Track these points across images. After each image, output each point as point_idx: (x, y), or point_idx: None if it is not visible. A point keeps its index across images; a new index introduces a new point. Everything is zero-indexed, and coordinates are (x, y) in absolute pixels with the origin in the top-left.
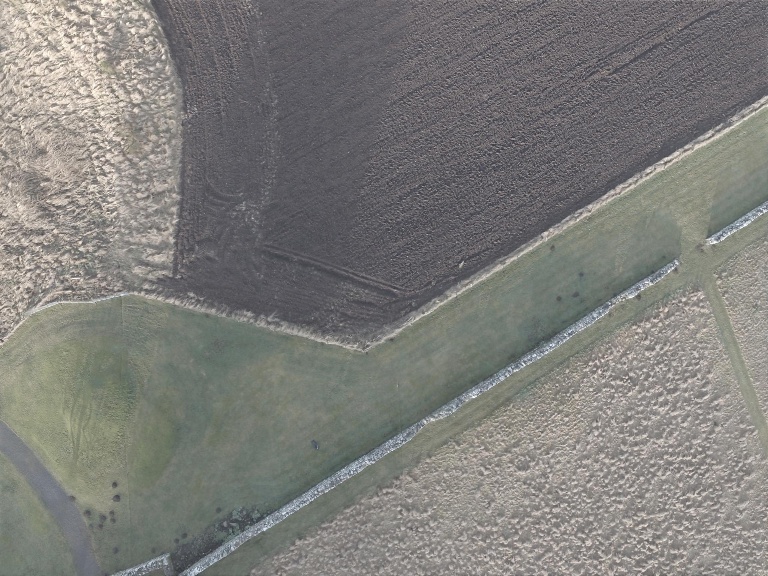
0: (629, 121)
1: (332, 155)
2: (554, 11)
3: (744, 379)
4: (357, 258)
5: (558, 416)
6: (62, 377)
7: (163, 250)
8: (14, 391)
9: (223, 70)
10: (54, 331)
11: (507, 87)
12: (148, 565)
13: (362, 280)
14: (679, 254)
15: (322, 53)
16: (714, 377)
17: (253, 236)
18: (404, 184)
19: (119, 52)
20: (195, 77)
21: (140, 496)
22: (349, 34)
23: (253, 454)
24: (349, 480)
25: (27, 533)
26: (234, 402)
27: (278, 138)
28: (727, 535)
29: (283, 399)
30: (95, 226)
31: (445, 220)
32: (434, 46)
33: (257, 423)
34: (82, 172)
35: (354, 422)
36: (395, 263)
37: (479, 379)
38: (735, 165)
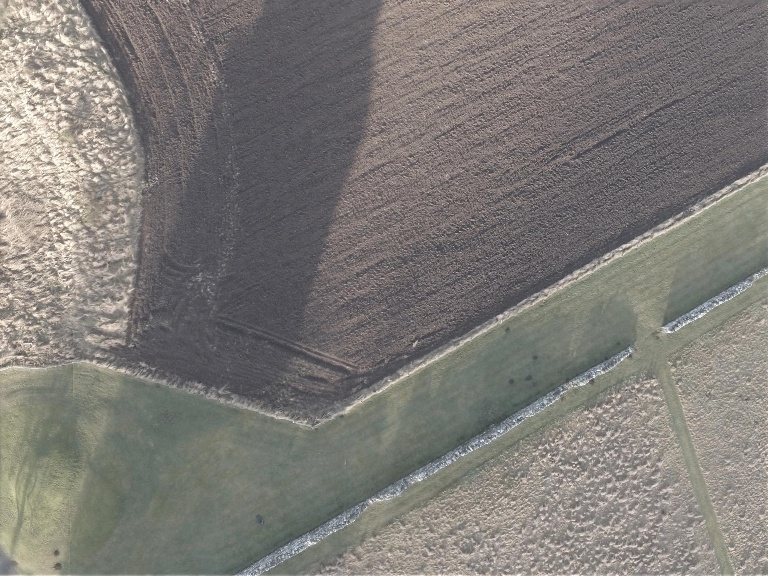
0: (589, 206)
1: (291, 229)
2: (519, 94)
3: (694, 468)
4: (311, 333)
5: (505, 499)
6: (10, 443)
7: (117, 319)
8: None
9: (186, 141)
10: (4, 395)
11: (469, 168)
12: None
13: (315, 355)
14: (634, 341)
15: (286, 127)
16: (664, 465)
17: (208, 308)
18: (361, 261)
19: (81, 121)
20: (157, 147)
21: (82, 565)
22: (313, 109)
23: (197, 526)
24: (293, 556)
25: None
26: (181, 474)
27: (238, 210)
28: None
29: (230, 472)
30: (50, 292)
31: (401, 299)
32: (398, 124)
33: (203, 495)
34: (40, 238)
35: (300, 498)
36: (349, 340)
37: (427, 460)
38: (694, 253)
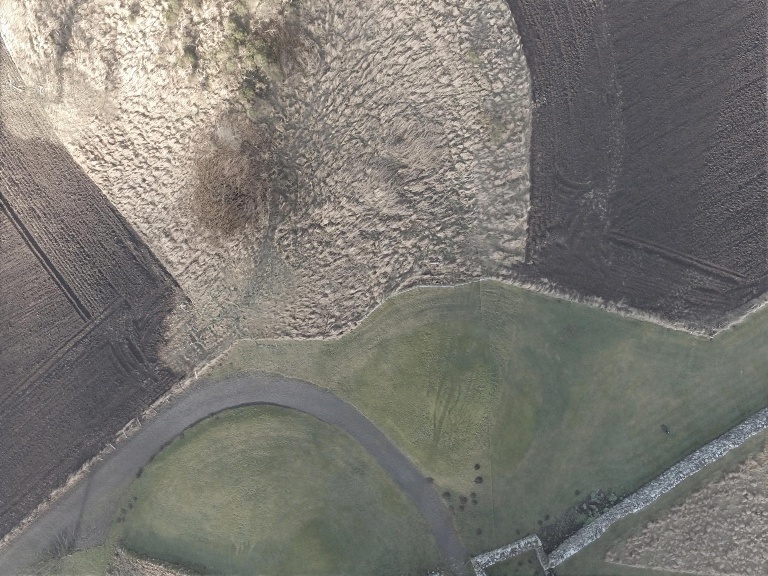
0: None
1: (674, 145)
2: None
3: None
4: (701, 246)
5: None
6: (425, 360)
7: (518, 236)
8: (366, 374)
9: (570, 61)
10: (412, 315)
11: None
12: (522, 545)
13: (705, 267)
14: None
15: (663, 45)
16: None
17: (601, 223)
18: (743, 174)
19: (481, 42)
20: (544, 67)
21: (503, 478)
22: (688, 27)
23: (606, 438)
24: None
25: (381, 514)
26: (588, 386)
27: (623, 128)
28: None
29: (632, 384)
30: (453, 212)
31: None
32: None
33: (609, 407)
34: (440, 159)
35: (702, 407)
36: (738, 251)
37: None
38: None
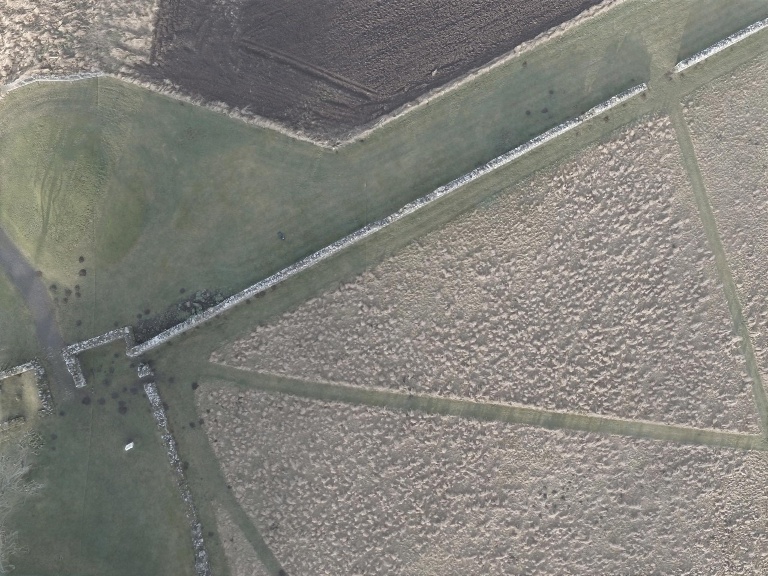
0: None
1: None
2: None
3: (704, 206)
4: (332, 59)
5: (521, 225)
6: (35, 151)
7: (142, 35)
8: None
9: None
10: (30, 108)
11: None
12: (110, 332)
13: (336, 81)
14: (648, 80)
15: None
16: (675, 202)
17: (231, 30)
18: None
19: None
20: None
21: (106, 271)
22: None
23: (220, 240)
24: (313, 274)
25: None
26: (204, 188)
27: None
28: (679, 353)
29: (252, 190)
30: (76, 7)
31: (421, 28)
32: None
33: (225, 211)
34: None
35: (320, 216)
36: (369, 66)
37: (445, 183)
38: None
